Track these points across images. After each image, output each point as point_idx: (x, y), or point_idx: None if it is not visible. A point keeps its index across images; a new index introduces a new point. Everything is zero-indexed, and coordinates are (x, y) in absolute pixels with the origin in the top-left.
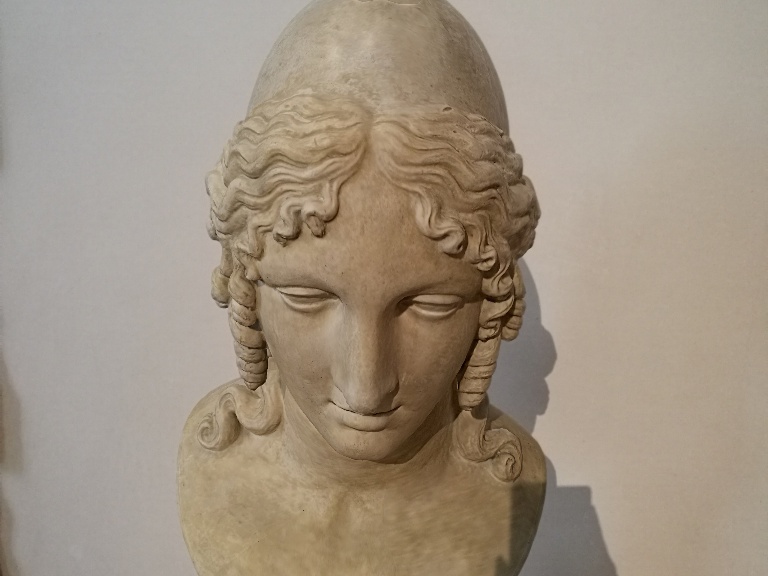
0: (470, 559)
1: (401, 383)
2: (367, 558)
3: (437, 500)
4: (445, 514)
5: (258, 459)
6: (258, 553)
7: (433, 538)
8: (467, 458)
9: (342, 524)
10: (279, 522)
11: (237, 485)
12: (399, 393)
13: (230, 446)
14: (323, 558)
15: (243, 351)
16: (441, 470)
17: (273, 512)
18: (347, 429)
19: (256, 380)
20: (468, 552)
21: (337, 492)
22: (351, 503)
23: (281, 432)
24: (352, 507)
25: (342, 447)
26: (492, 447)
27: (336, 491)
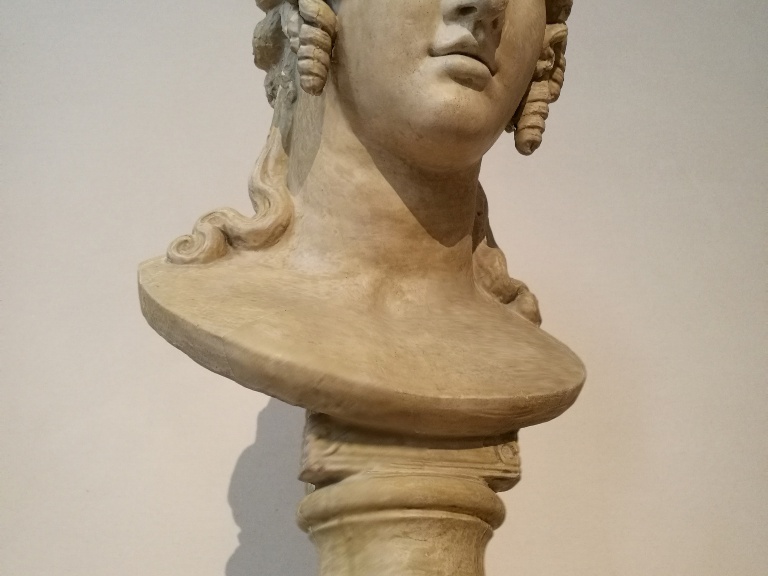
0: (536, 349)
1: (503, 35)
2: (427, 330)
3: (477, 311)
4: (491, 321)
5: (258, 267)
6: (290, 315)
7: (489, 331)
8: (492, 290)
9: (382, 314)
10: (306, 302)
11: (237, 282)
12: (499, 49)
13: (217, 260)
14: (375, 326)
15: (316, 30)
16: (472, 291)
17: (294, 296)
18: (446, 83)
19: (321, 73)
20: (531, 345)
21: (372, 279)
22: (388, 296)
23: (287, 240)
24: (389, 301)
25: (440, 104)
26: (514, 282)
27: (371, 277)
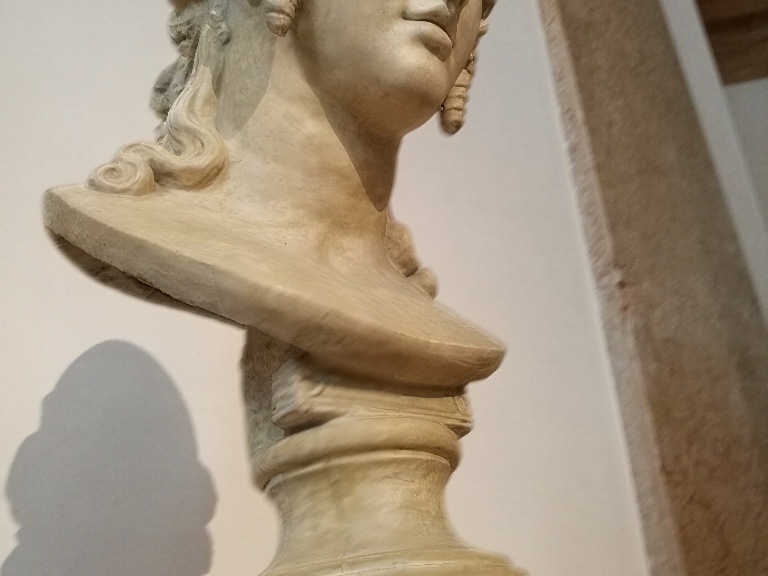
0: None
1: (461, 14)
2: (379, 285)
3: None
4: None
5: (196, 206)
6: (263, 254)
7: None
8: (399, 261)
9: None
10: (264, 245)
11: (183, 218)
12: (457, 27)
13: (149, 194)
14: None
15: None
16: None
17: (250, 238)
18: (418, 47)
19: (292, 14)
20: None
21: (316, 232)
22: (330, 251)
23: (221, 184)
24: (331, 256)
25: (413, 66)
26: None
27: (315, 230)
